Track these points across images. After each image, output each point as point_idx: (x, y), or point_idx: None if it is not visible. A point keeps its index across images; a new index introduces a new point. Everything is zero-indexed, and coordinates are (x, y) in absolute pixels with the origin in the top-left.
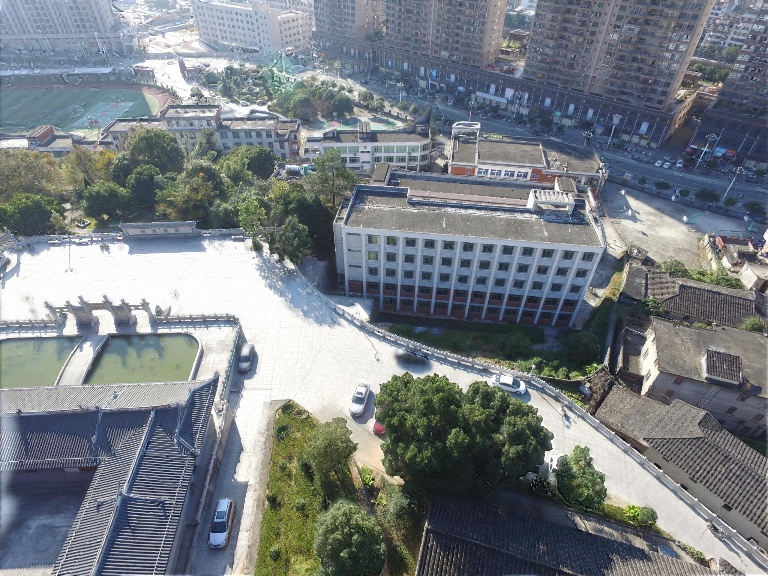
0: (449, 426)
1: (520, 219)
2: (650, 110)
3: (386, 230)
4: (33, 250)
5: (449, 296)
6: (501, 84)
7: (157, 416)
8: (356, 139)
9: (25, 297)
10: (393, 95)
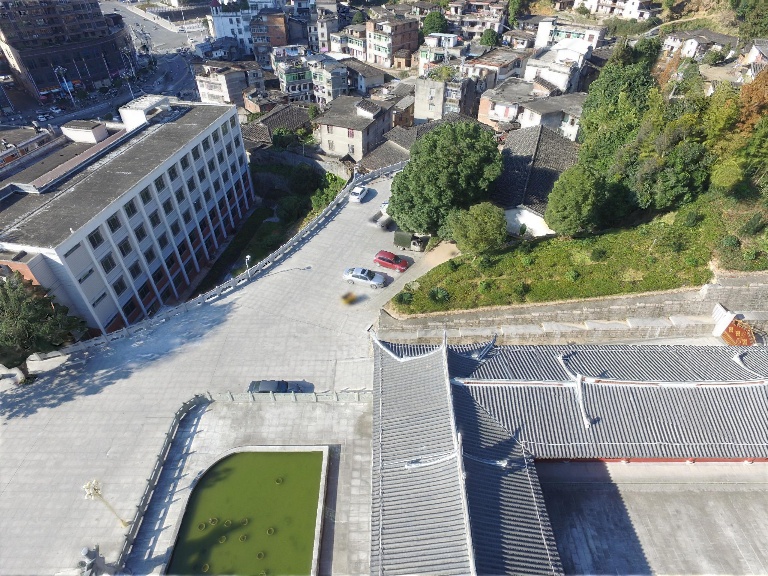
0: None
1: (156, 132)
2: None
3: (103, 210)
4: None
5: (188, 248)
6: None
7: None
8: None
9: None
10: None
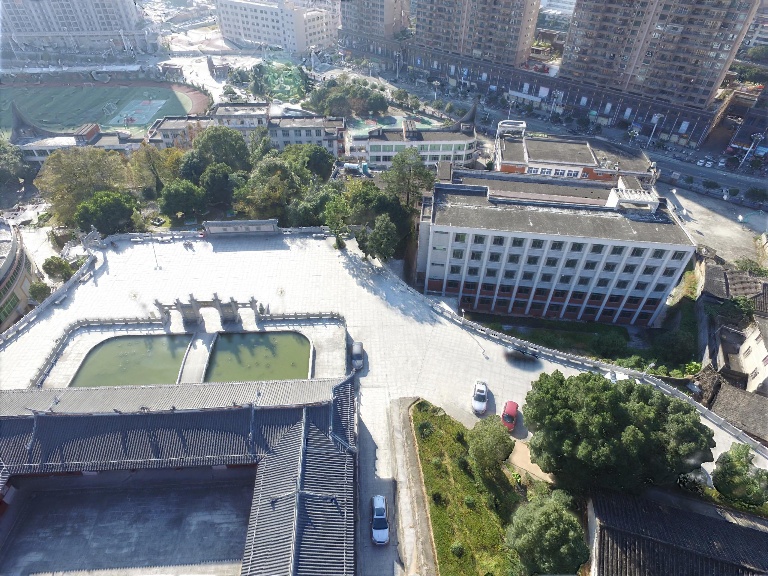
0: (618, 423)
1: (605, 218)
2: (691, 109)
3: (476, 228)
4: (117, 248)
5: (530, 294)
6: (535, 83)
7: (309, 413)
8: (402, 138)
9: (133, 295)
10: (426, 94)
